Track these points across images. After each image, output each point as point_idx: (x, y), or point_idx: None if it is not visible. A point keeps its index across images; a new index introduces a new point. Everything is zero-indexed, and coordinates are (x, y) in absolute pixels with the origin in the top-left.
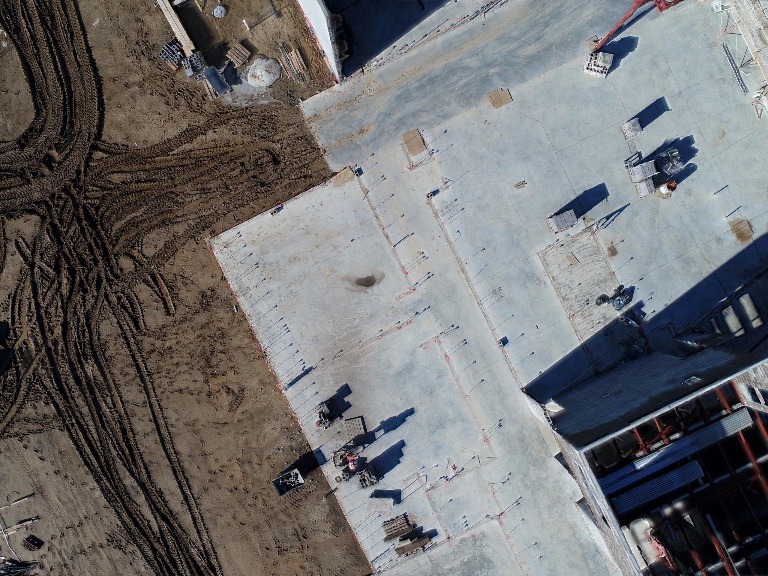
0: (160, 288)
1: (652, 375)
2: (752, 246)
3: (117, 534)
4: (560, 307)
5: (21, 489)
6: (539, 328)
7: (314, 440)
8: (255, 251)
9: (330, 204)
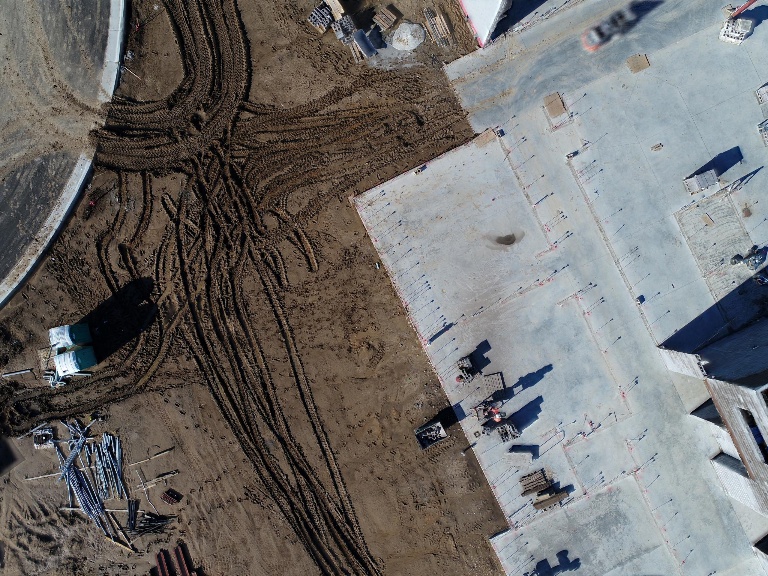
0: (303, 245)
1: None
2: None
3: (256, 488)
4: (695, 267)
5: (161, 443)
6: (675, 287)
7: (454, 395)
8: (398, 209)
9: (472, 164)
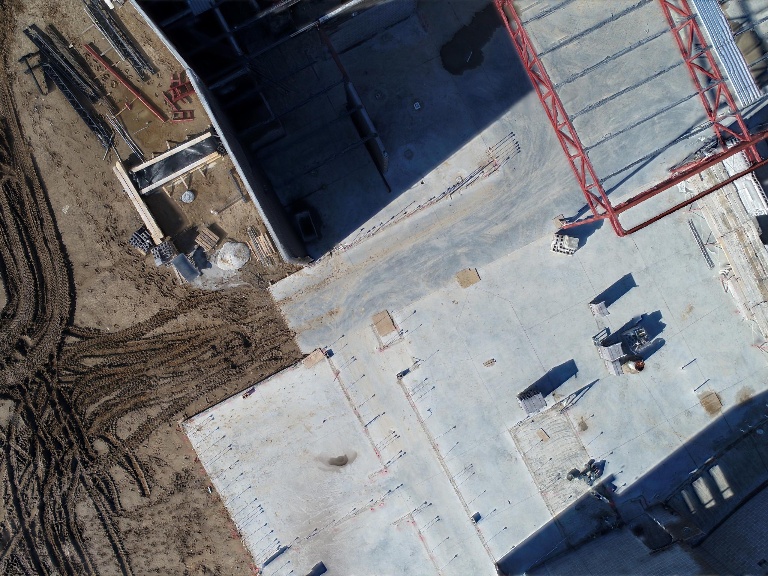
0: (135, 469)
1: (620, 570)
2: (721, 418)
3: None
4: (532, 482)
5: None
6: (511, 503)
7: None
8: (228, 433)
9: (301, 385)
